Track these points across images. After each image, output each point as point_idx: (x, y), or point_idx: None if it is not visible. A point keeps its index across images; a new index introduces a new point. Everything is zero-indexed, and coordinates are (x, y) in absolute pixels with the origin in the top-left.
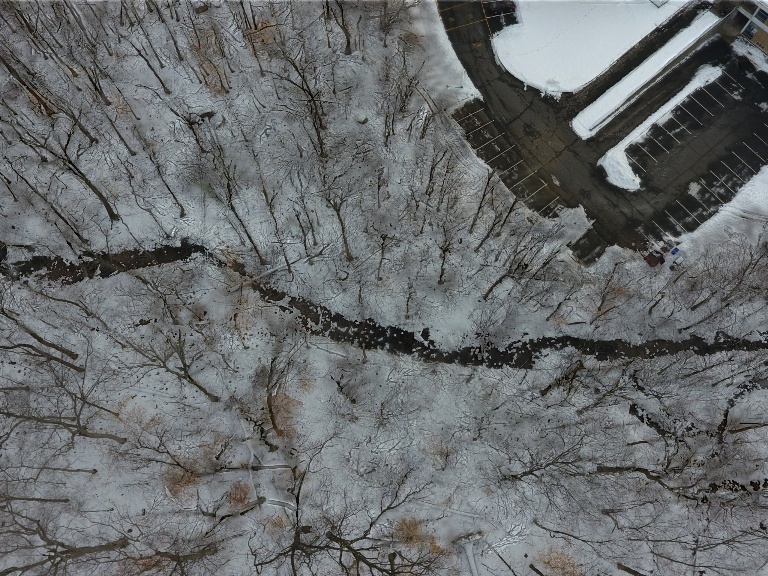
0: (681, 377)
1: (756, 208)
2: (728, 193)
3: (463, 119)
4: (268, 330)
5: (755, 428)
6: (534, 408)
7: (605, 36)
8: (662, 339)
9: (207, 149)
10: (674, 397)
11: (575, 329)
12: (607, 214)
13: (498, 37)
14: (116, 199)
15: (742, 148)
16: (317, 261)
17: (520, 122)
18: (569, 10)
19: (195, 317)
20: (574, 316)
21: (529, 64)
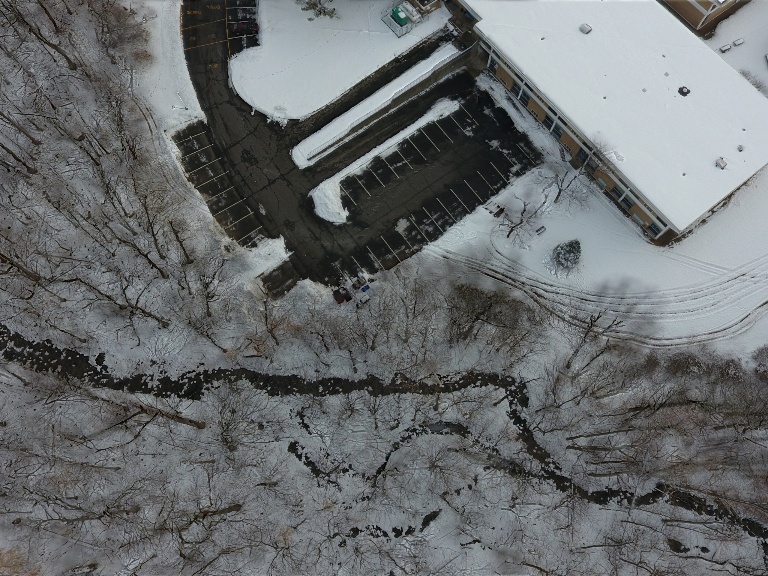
0: (344, 417)
1: (460, 249)
2: (436, 232)
3: (182, 141)
4: None
5: None
6: (186, 441)
7: (342, 64)
8: (338, 377)
9: None
10: None
11: (250, 362)
12: (307, 247)
13: (235, 59)
14: None
15: (462, 186)
16: (3, 279)
17: (239, 147)
18: (312, 35)
19: None
20: (250, 349)
21: (261, 88)
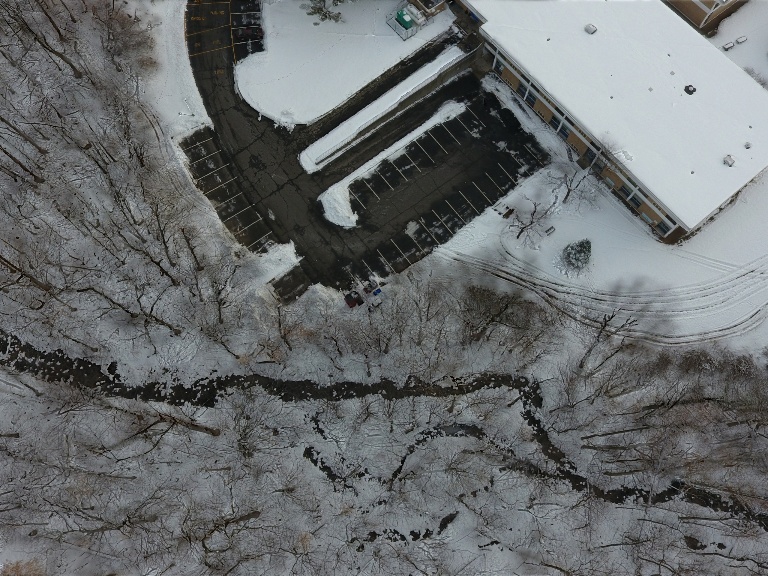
0: (359, 422)
1: (470, 250)
2: (446, 234)
3: (190, 148)
4: None
5: None
6: (201, 448)
7: (348, 68)
8: (352, 381)
9: None
10: None
11: (263, 368)
12: (317, 251)
13: (241, 64)
14: None
15: (470, 188)
16: (13, 289)
17: (247, 153)
18: (317, 39)
19: None
20: (263, 355)
21: (267, 94)
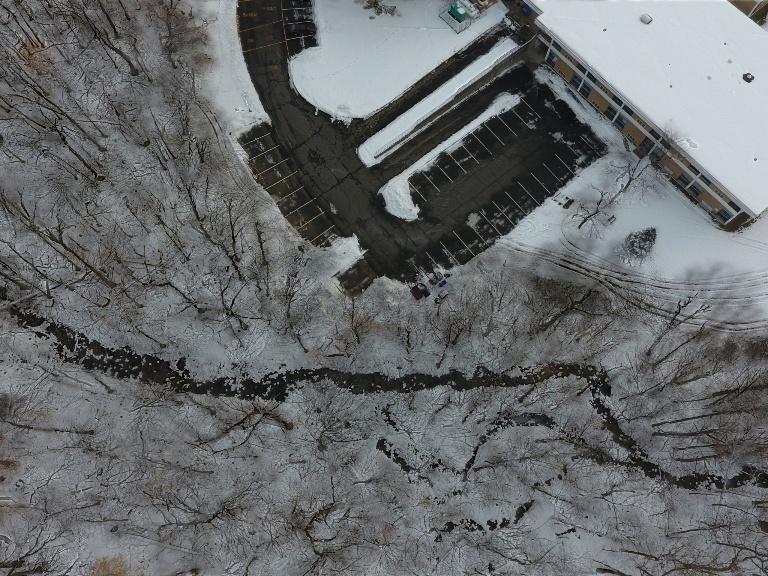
0: (431, 413)
1: (532, 241)
2: (507, 225)
3: (248, 143)
4: (20, 357)
5: (482, 469)
6: (276, 442)
7: (402, 61)
8: (421, 373)
9: None
10: None
11: (332, 361)
12: (380, 244)
13: (295, 60)
14: None
15: (529, 179)
16: (78, 287)
17: (306, 148)
18: (370, 34)
19: None
20: (332, 348)
21: (323, 88)
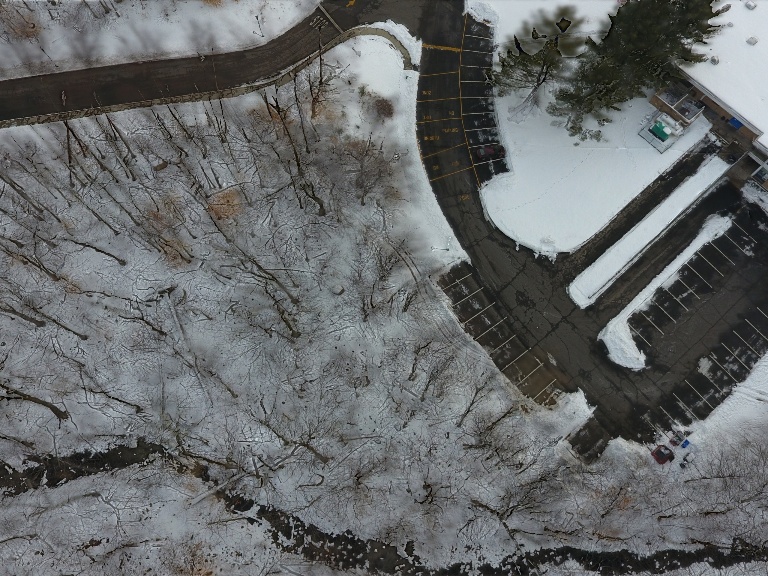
0: None
1: None
2: (742, 370)
3: (449, 287)
4: (234, 549)
5: None
6: None
7: (604, 186)
8: (673, 549)
9: None
10: None
11: (576, 540)
12: (609, 399)
13: (487, 188)
14: (64, 395)
15: (756, 314)
16: (288, 463)
17: (512, 289)
18: (564, 155)
19: (151, 537)
20: (575, 525)
21: (521, 219)
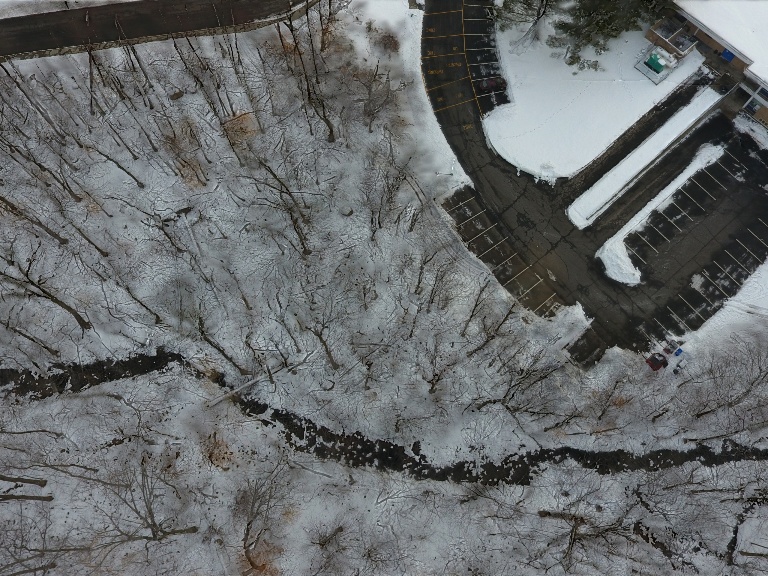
0: (687, 493)
1: (763, 302)
2: (733, 286)
3: (453, 209)
4: (249, 448)
5: (767, 558)
6: (532, 532)
7: (601, 116)
8: (666, 449)
9: (183, 248)
10: (680, 515)
11: (574, 440)
12: (606, 312)
13: (489, 118)
14: (87, 306)
15: (747, 235)
16: (301, 370)
17: (513, 211)
18: (563, 87)
19: (171, 436)
20: (573, 426)
21: (522, 147)
